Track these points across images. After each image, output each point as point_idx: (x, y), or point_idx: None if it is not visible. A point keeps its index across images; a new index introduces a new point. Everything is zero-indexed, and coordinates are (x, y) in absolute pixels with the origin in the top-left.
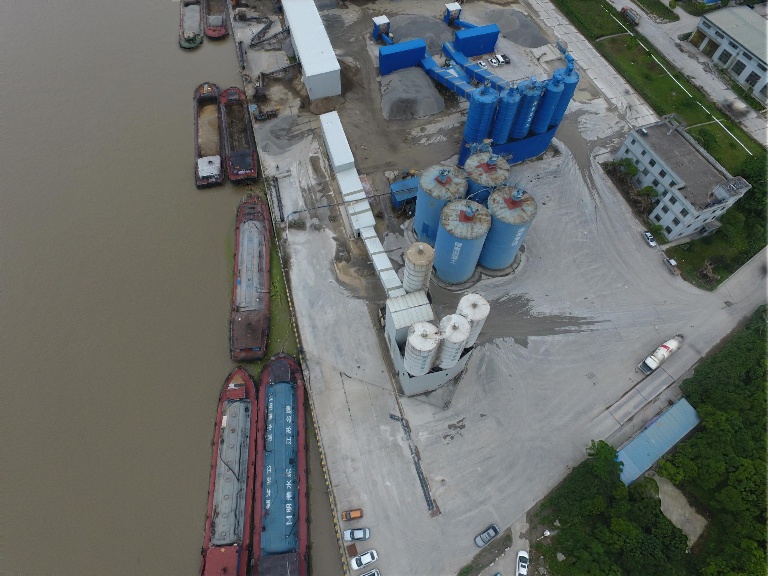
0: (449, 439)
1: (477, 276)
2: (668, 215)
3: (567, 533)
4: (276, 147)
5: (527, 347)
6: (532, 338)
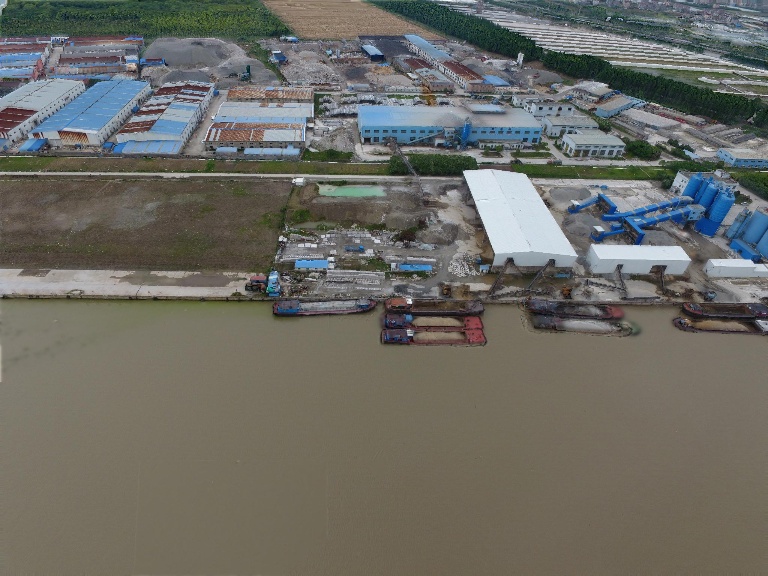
0: None
1: None
2: None
3: None
4: None
5: None
6: None
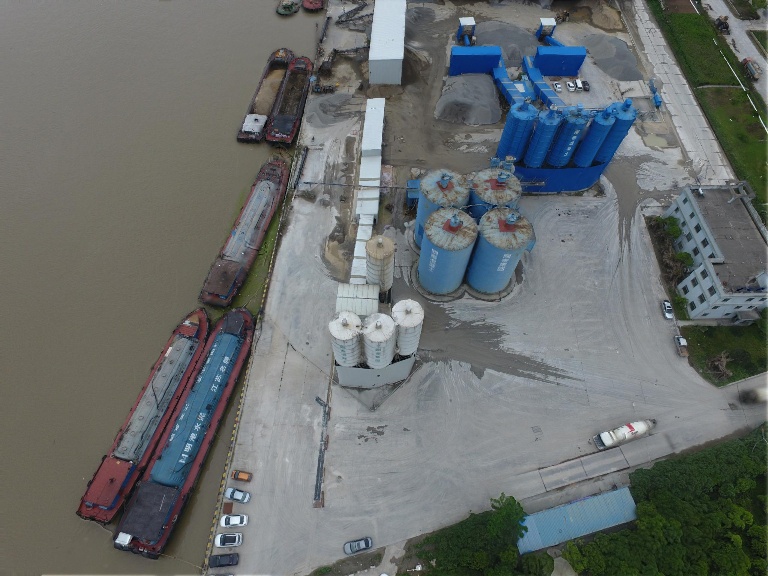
0: (363, 440)
1: (460, 293)
2: (696, 289)
3: (437, 575)
4: (320, 120)
5: (481, 378)
6: (490, 371)
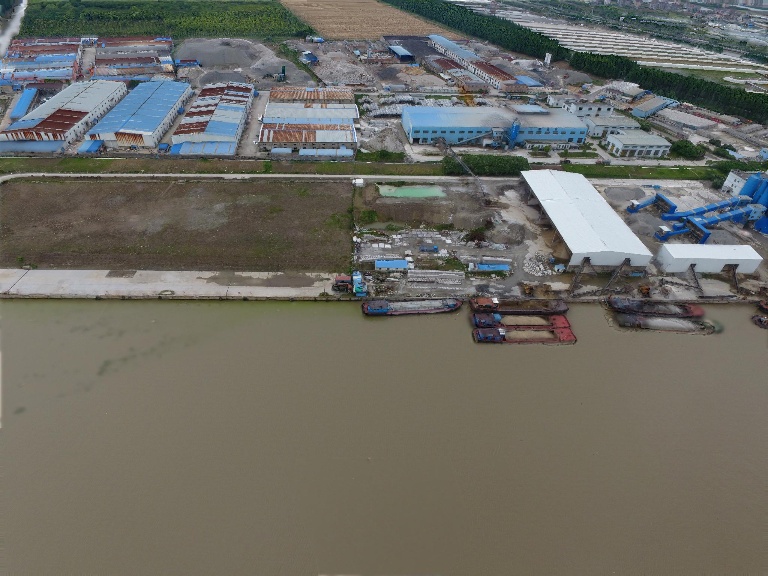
0: None
1: None
2: None
3: None
4: None
5: None
6: None
